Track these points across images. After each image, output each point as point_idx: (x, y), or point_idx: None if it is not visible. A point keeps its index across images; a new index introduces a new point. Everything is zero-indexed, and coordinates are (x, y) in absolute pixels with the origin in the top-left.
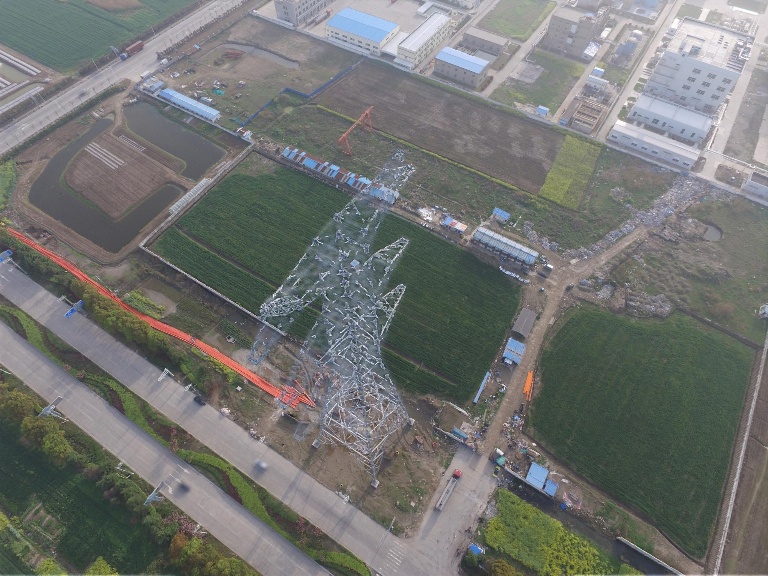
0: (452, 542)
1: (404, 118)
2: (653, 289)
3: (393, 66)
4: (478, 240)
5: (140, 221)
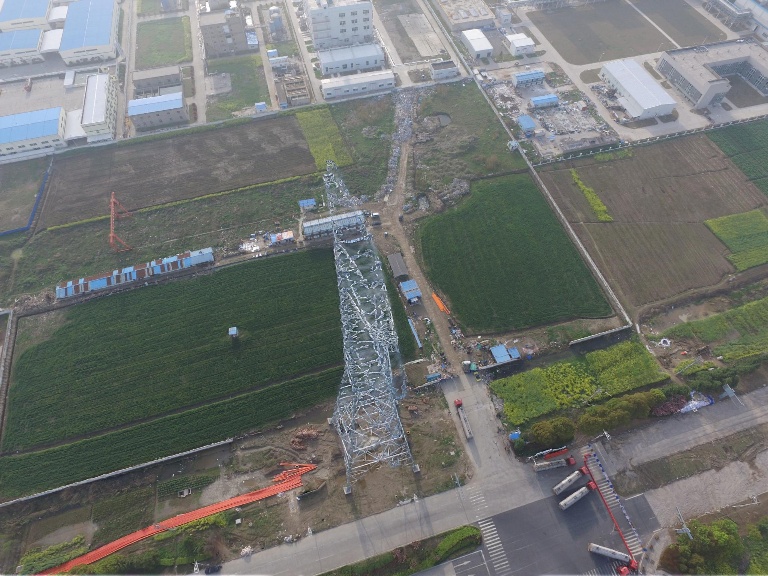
0: (498, 448)
1: (149, 184)
2: (447, 179)
3: (91, 147)
4: (311, 235)
5: None
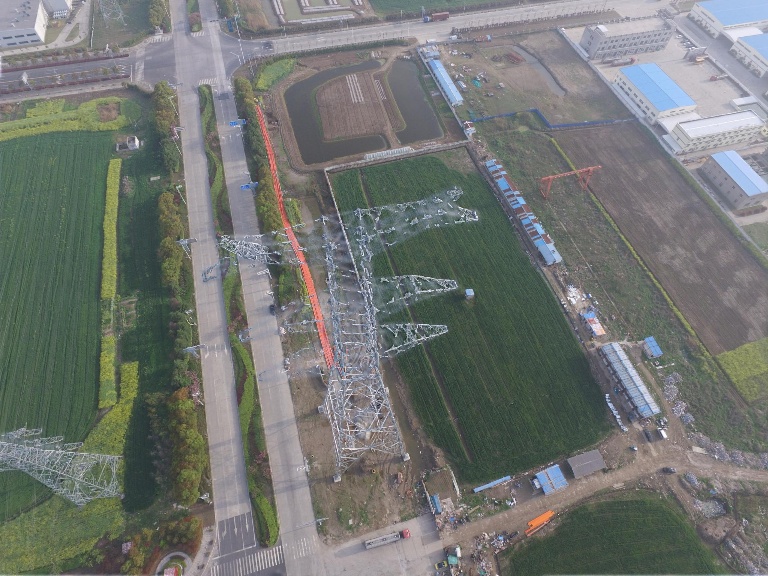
0: None
1: (628, 195)
2: None
3: (658, 141)
4: (605, 353)
5: (340, 151)
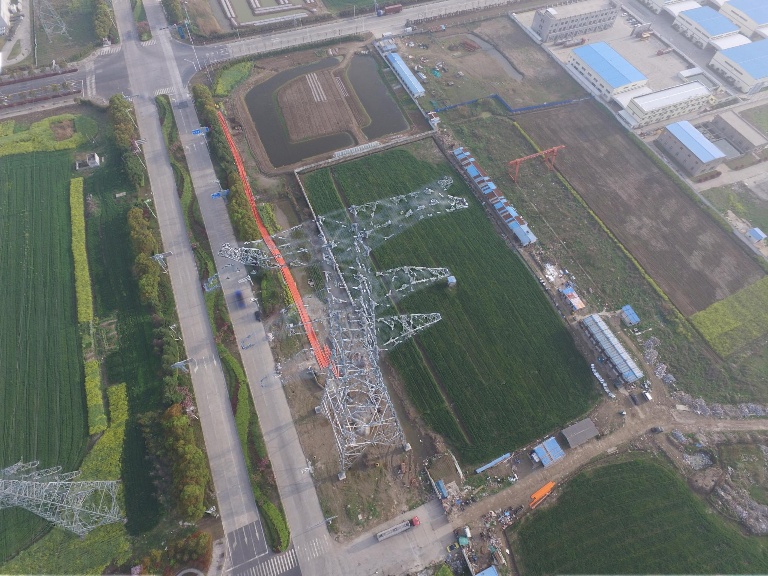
0: (370, 575)
1: (592, 171)
2: (761, 495)
3: (615, 117)
4: (586, 325)
5: (308, 152)
